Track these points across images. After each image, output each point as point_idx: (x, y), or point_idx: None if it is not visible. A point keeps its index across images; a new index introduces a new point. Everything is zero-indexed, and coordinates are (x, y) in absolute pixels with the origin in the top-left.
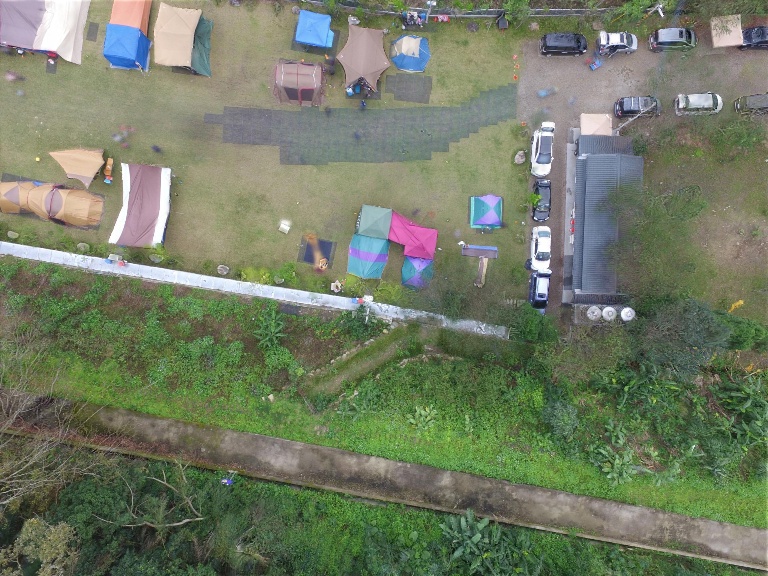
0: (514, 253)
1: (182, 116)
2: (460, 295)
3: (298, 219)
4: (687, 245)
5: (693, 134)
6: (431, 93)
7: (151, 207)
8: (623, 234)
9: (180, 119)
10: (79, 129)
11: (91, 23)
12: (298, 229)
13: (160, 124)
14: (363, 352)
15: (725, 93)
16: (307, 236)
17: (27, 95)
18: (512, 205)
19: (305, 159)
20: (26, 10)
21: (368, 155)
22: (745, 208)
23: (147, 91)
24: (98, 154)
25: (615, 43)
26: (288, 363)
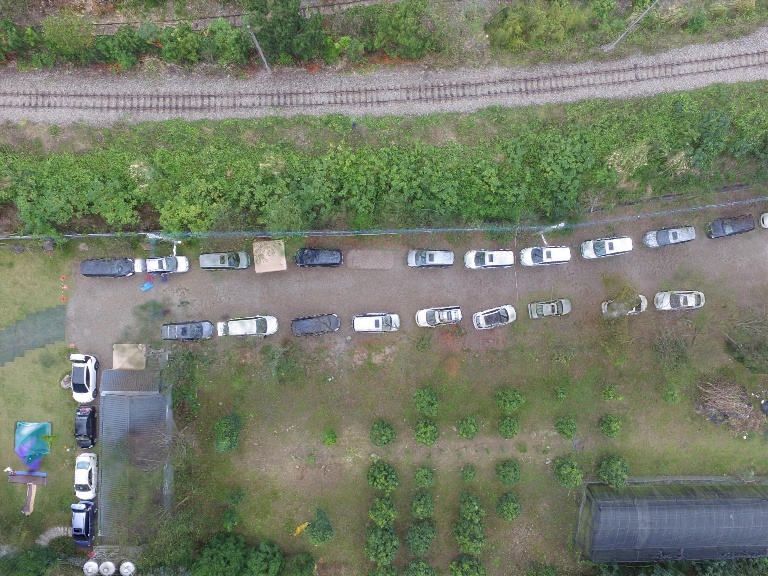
0: (64, 479)
1: None
2: (0, 527)
3: None
4: (244, 469)
5: (253, 353)
6: None
7: None
8: (136, 479)
9: None
10: None
11: None
12: None
13: None
14: None
15: (286, 311)
16: None
17: None
18: (61, 429)
19: None
20: None
21: None
22: (309, 428)
23: None
24: None
25: (153, 270)
26: None
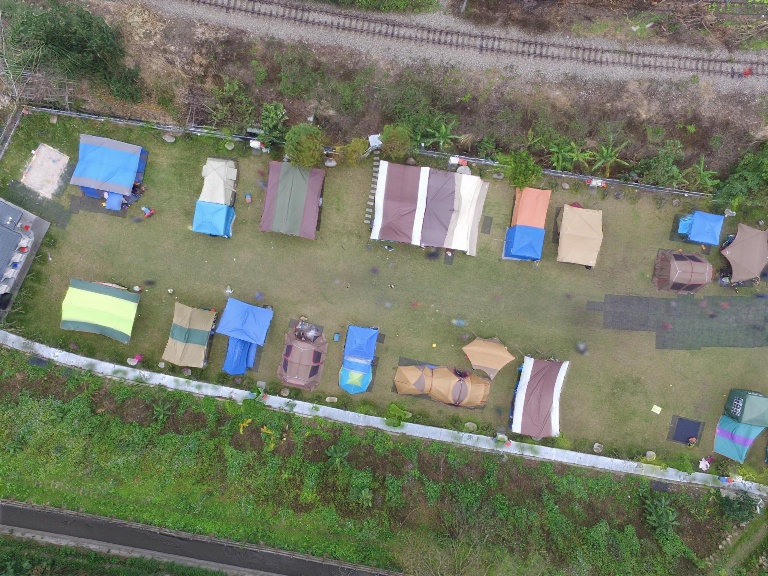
0: None
1: (566, 303)
2: None
3: (670, 400)
4: None
5: None
6: None
7: (547, 395)
8: None
9: (564, 306)
10: (471, 316)
11: (486, 217)
12: (669, 410)
13: (545, 311)
14: (744, 536)
15: None
16: (677, 416)
17: (425, 285)
18: None
19: (679, 344)
20: (441, 212)
21: (739, 340)
22: None
23: (535, 280)
24: (503, 347)
25: None
26: (684, 550)
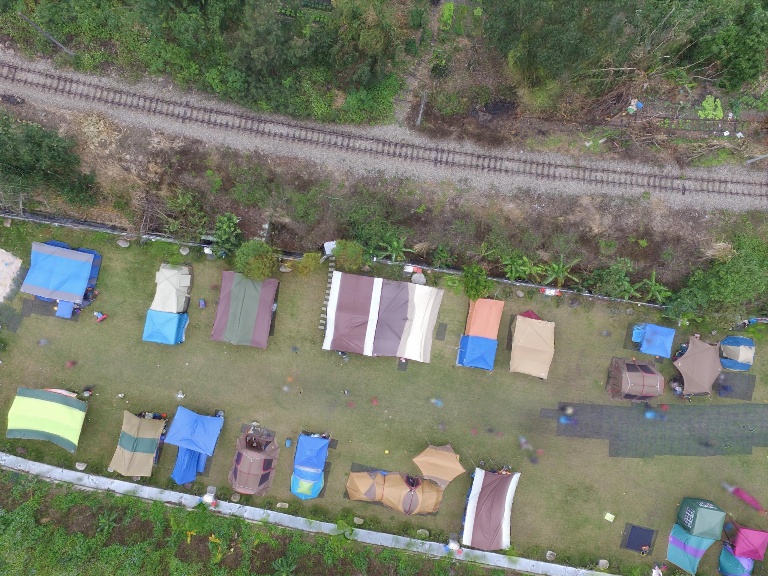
0: None
1: (520, 411)
2: None
3: (623, 508)
4: None
5: None
6: (754, 391)
7: (498, 506)
8: None
9: (518, 413)
10: (425, 423)
11: (440, 324)
12: (622, 517)
13: (499, 418)
14: None
15: None
16: (631, 524)
17: (379, 391)
18: None
19: (633, 452)
20: (394, 322)
21: (692, 449)
22: None
23: (488, 387)
24: (454, 458)
25: None
26: None
